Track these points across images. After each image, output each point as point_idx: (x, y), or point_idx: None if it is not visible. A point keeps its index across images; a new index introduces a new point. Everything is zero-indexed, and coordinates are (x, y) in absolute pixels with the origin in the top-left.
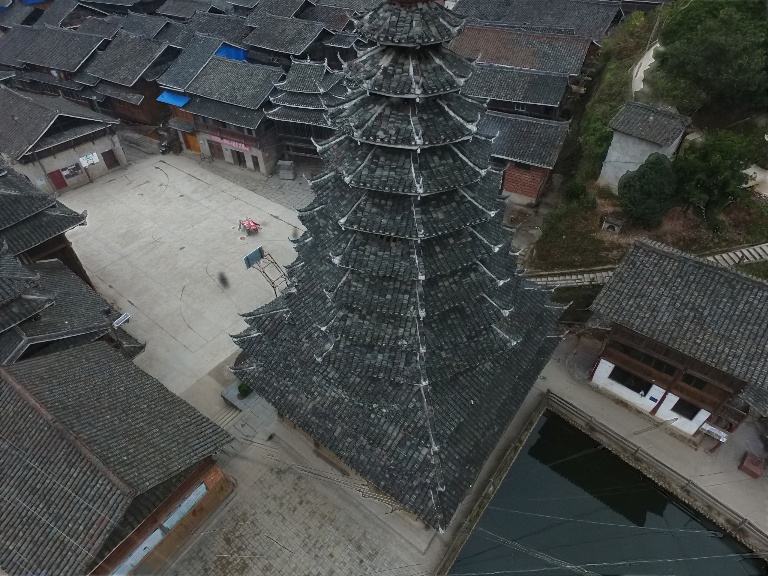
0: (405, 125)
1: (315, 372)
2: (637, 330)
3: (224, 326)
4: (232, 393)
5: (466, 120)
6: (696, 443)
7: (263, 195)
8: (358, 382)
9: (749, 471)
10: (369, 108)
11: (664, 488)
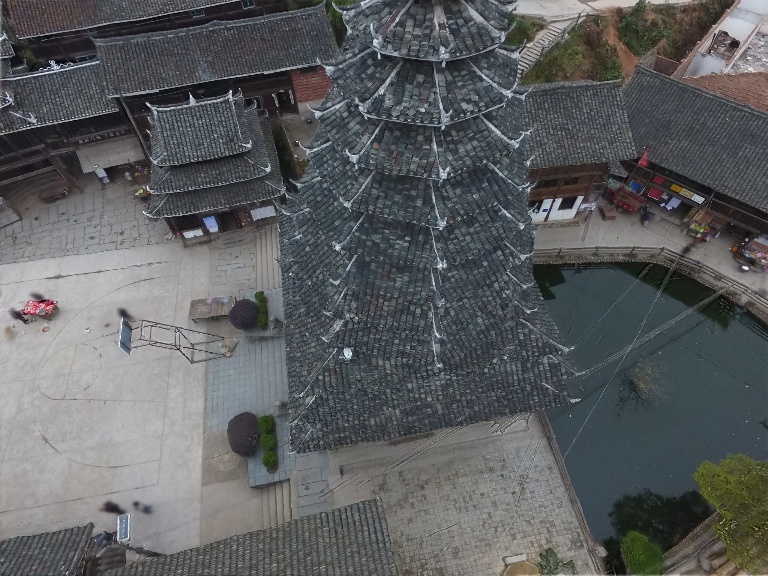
0: (480, 83)
1: (405, 380)
2: (542, 167)
3: (156, 431)
4: (260, 475)
5: (511, 50)
6: (578, 221)
7: (1, 263)
8: (464, 355)
9: (610, 217)
10: (422, 81)
11: (584, 263)
